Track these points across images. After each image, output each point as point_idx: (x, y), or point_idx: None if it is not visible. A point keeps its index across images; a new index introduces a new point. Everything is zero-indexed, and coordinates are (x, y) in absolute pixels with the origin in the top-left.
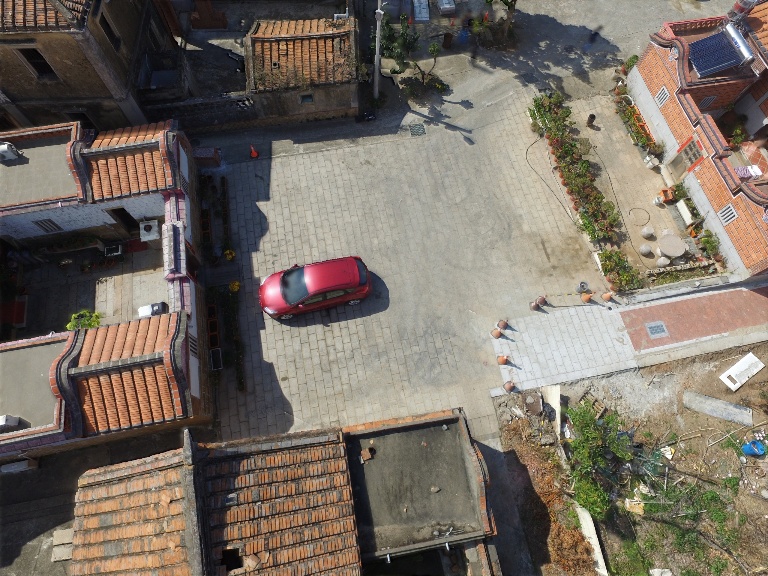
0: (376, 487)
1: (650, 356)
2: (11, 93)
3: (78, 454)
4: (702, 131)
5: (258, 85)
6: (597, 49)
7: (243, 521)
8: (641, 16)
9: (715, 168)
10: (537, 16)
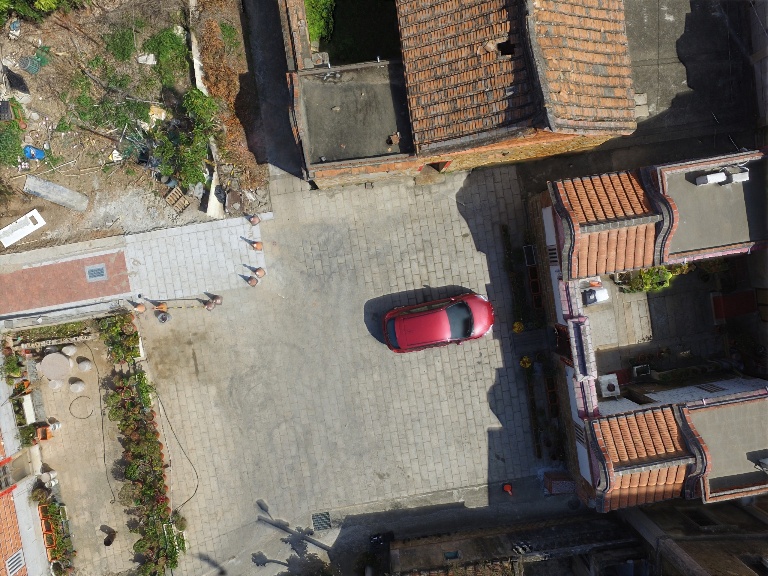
0: (387, 114)
1: (110, 246)
2: None
3: None
4: None
5: (510, 568)
6: None
7: (499, 76)
8: None
9: None
10: None
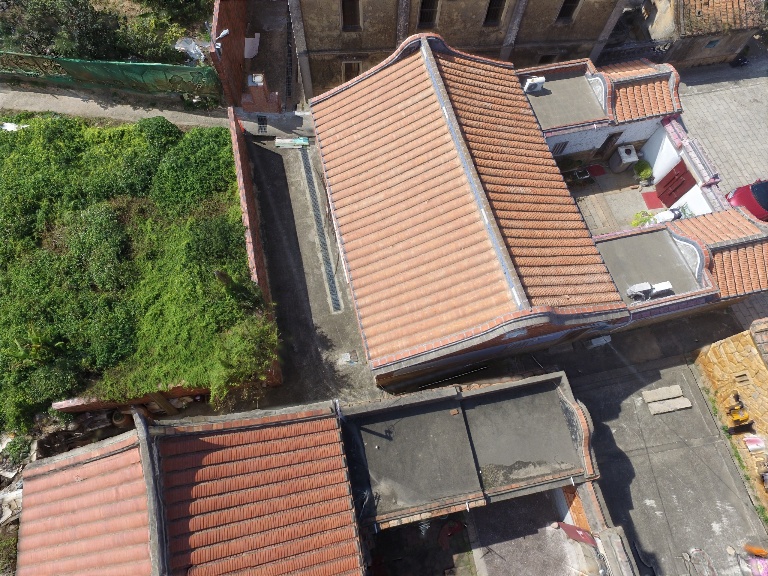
0: None
1: None
2: (519, 36)
3: (629, 334)
4: None
5: (686, 31)
6: None
7: None
8: None
9: None
10: None
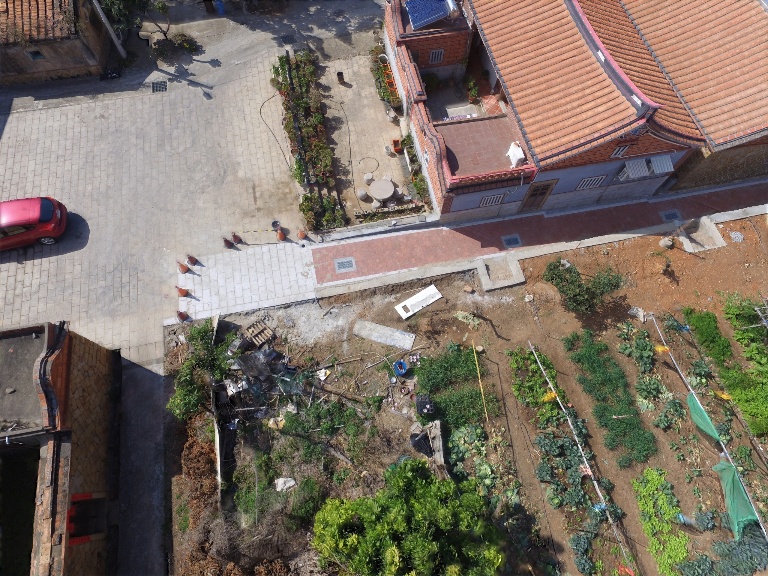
0: None
1: (330, 288)
2: None
3: None
4: None
5: None
6: (367, 13)
7: None
8: None
9: None
10: None
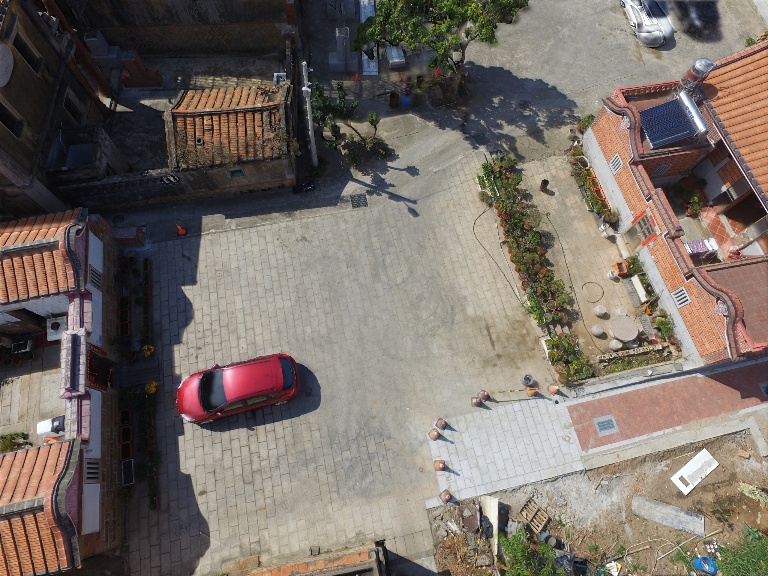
0: None
1: (598, 457)
2: None
3: None
4: (654, 207)
5: (181, 163)
6: (553, 105)
7: None
8: (600, 68)
9: (668, 247)
10: (492, 69)
